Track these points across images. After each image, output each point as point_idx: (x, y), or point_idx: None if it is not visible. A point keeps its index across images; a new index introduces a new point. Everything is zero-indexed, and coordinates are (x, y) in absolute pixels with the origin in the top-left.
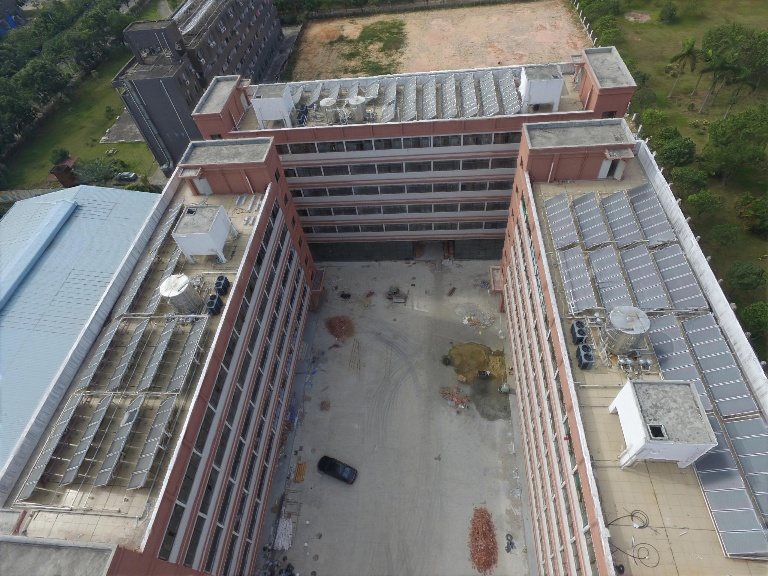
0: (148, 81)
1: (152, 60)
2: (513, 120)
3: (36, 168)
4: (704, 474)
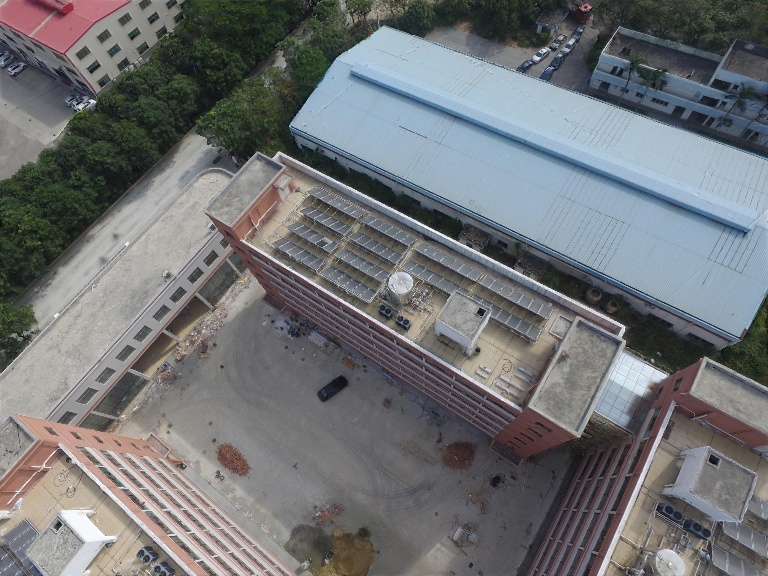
0: None
1: None
2: None
3: None
4: None
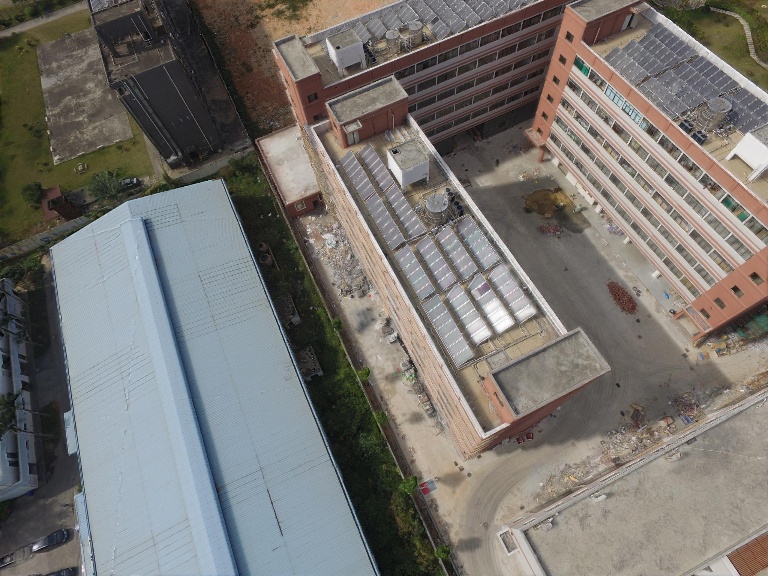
0: (150, 72)
1: (125, 50)
2: (537, 6)
3: (3, 216)
4: None
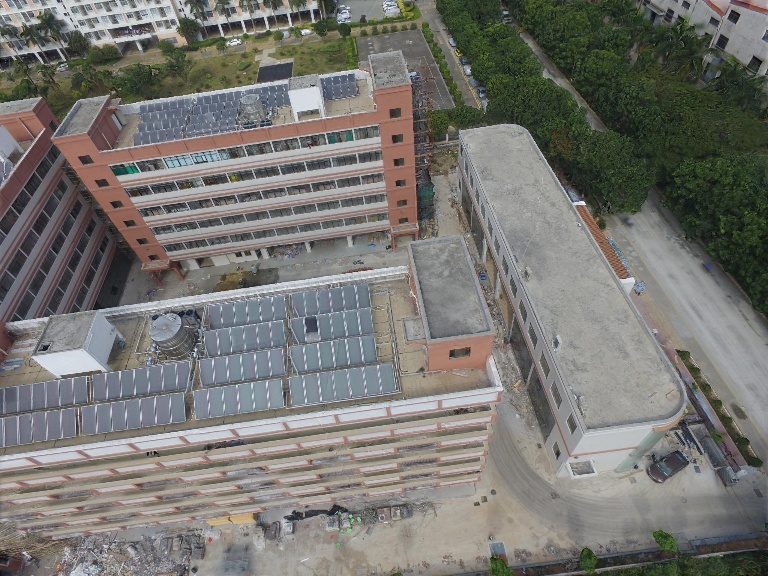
0: None
1: None
2: (21, 168)
3: None
4: (327, 97)
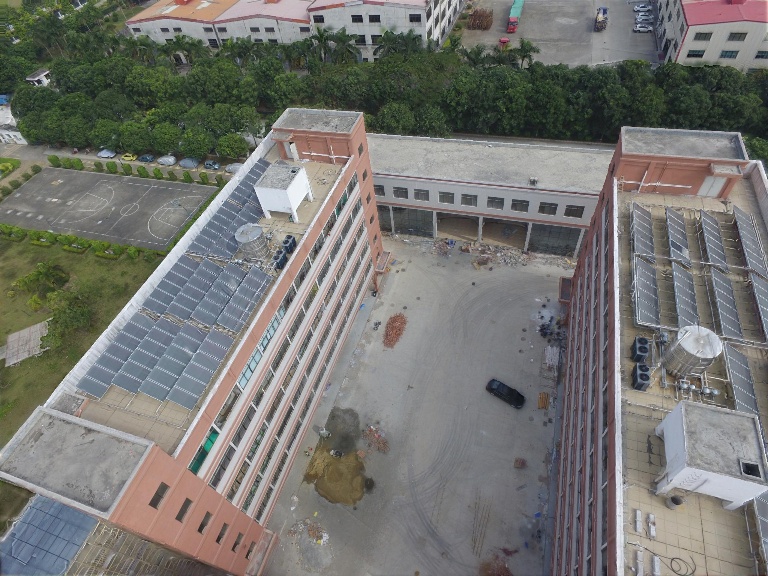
0: None
1: None
2: None
3: None
4: None
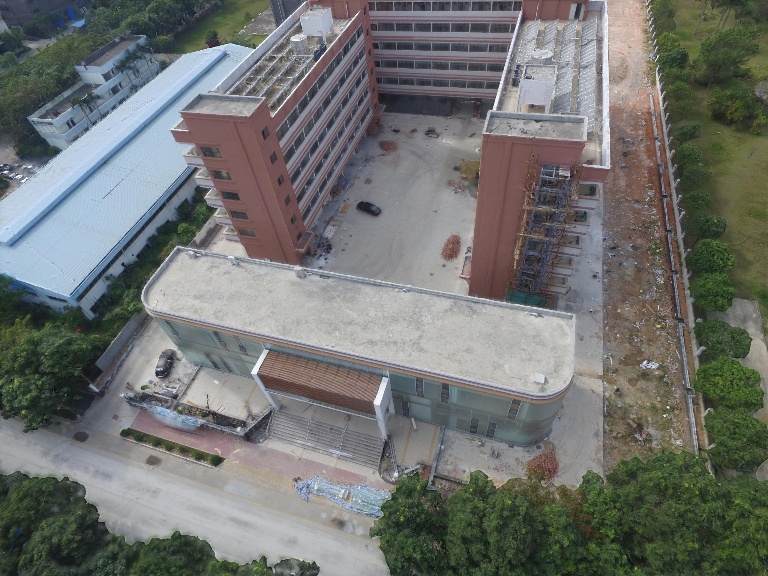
0: None
1: None
2: None
3: (193, 45)
4: None
